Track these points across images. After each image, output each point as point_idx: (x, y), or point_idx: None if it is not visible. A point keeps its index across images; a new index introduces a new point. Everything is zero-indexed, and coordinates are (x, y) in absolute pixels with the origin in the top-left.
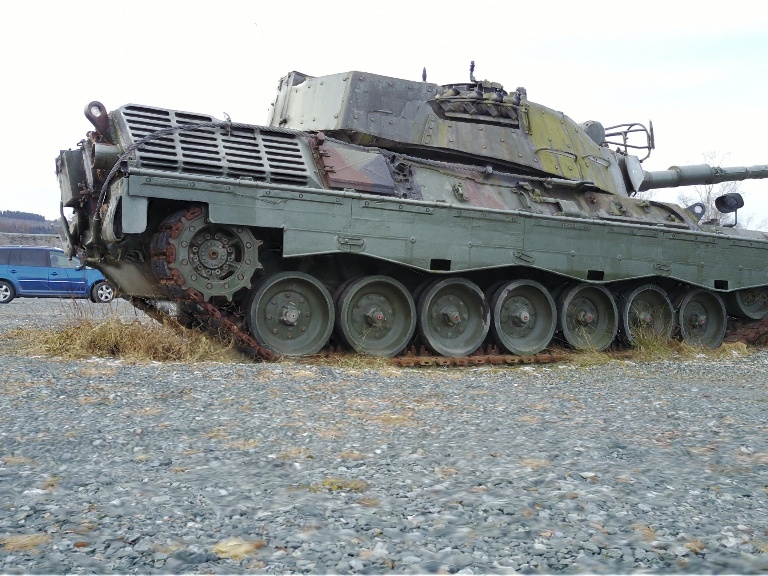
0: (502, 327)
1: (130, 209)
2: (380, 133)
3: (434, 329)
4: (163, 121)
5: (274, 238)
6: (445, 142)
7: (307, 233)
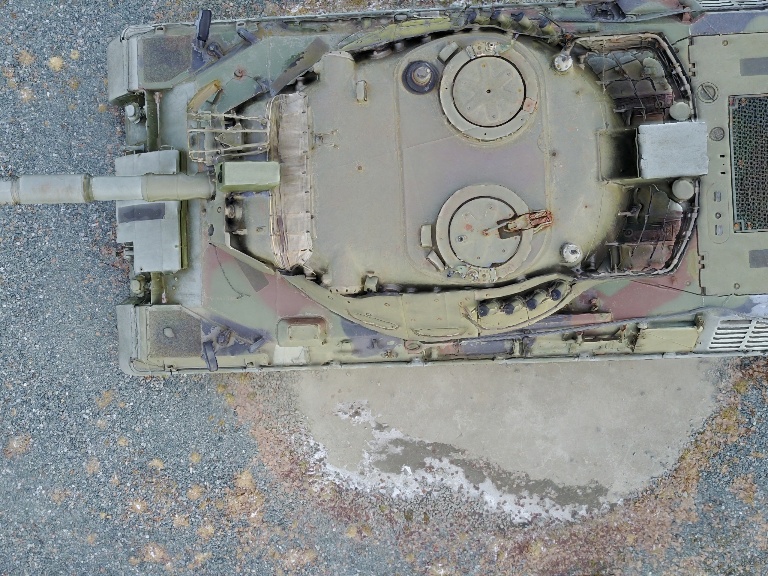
0: None
1: None
2: None
3: None
4: None
5: None
6: None
7: None
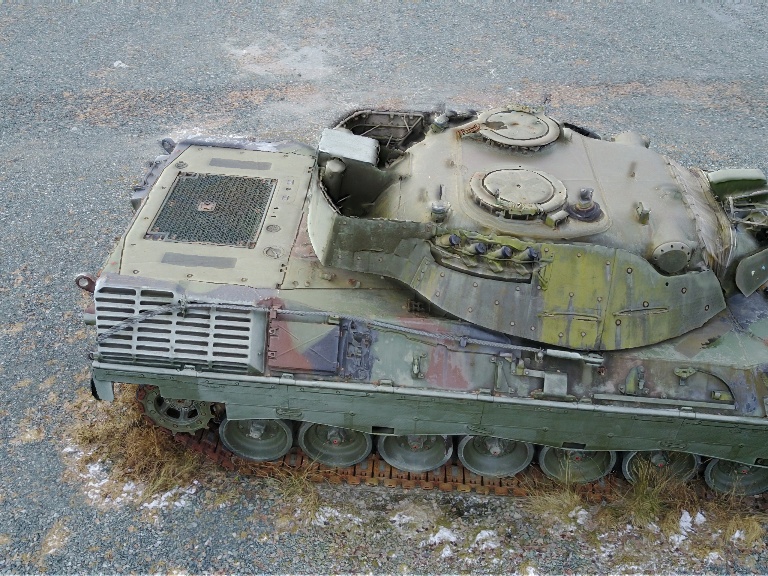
0: (475, 448)
1: (100, 386)
2: (368, 270)
3: (399, 444)
4: (129, 303)
5: (220, 405)
6: (431, 294)
7: (247, 406)
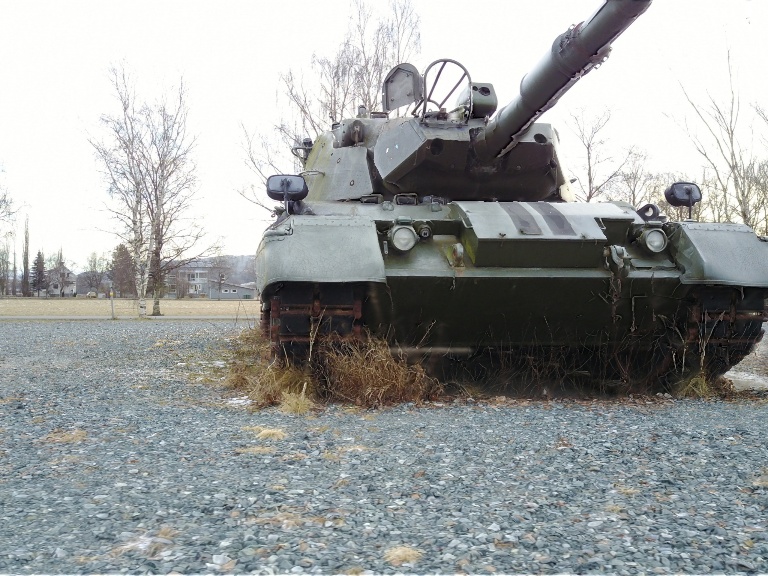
0: None
1: None
2: None
3: None
4: None
5: None
6: None
7: None
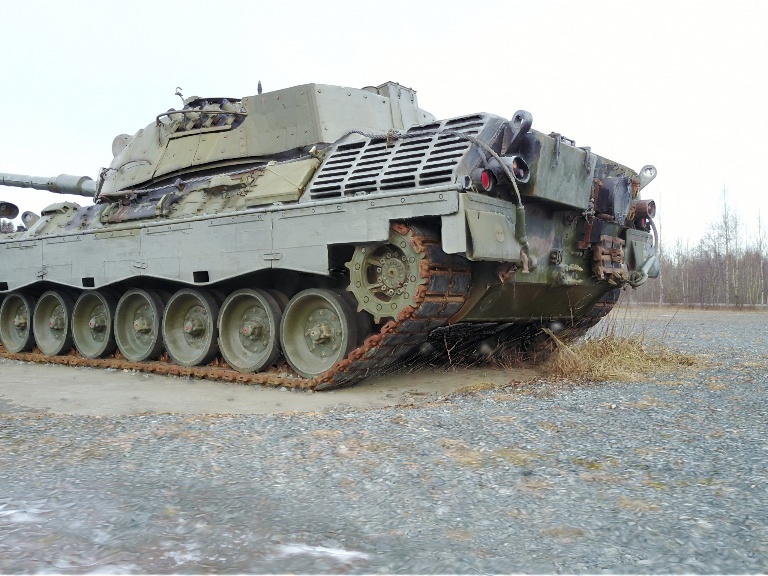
0: None
1: None
2: None
3: None
4: None
5: None
6: None
7: None
